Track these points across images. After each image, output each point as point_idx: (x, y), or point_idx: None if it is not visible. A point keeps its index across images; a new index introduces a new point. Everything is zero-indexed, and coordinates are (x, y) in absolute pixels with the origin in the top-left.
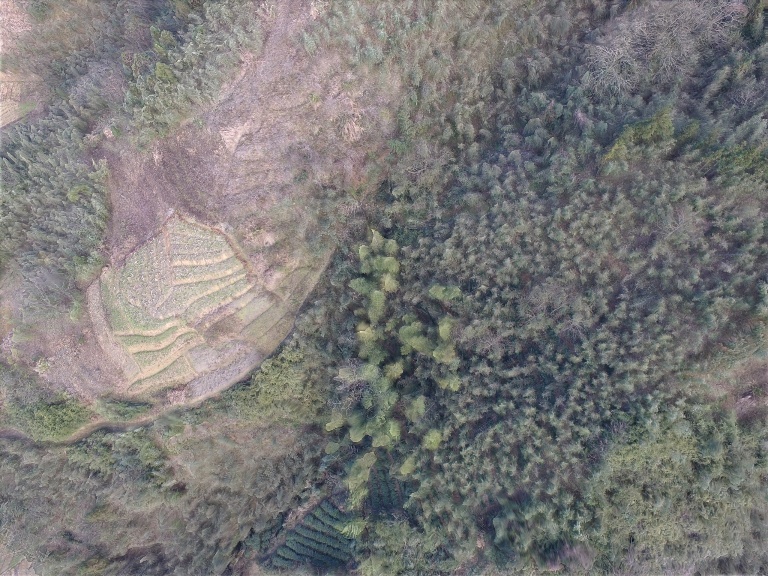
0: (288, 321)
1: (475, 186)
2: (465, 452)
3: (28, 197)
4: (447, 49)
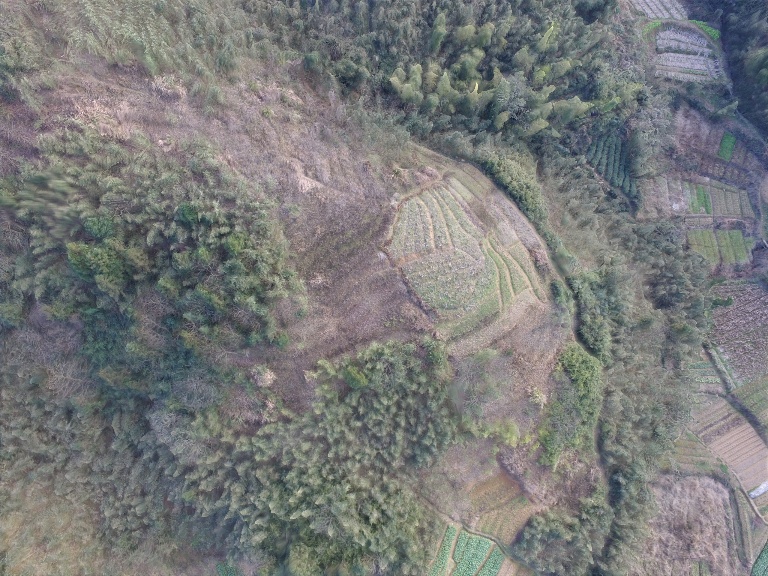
0: (465, 167)
1: (349, 6)
2: (551, 21)
3: (353, 466)
4: (219, 8)
